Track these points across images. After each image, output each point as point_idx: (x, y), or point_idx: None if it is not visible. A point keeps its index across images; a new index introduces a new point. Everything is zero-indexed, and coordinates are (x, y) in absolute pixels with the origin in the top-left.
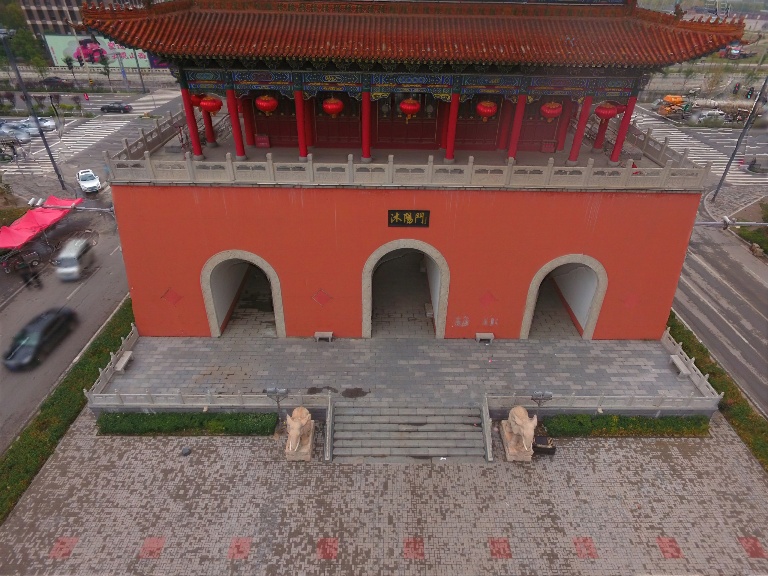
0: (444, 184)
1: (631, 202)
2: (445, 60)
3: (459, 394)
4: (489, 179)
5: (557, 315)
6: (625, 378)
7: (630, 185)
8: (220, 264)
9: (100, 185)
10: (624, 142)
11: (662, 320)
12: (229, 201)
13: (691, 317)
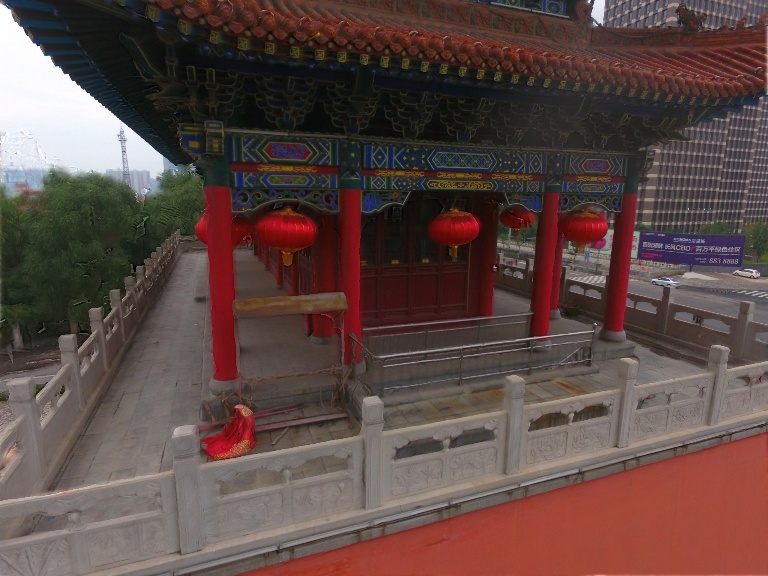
0: None
1: None
2: None
3: None
4: None
5: None
6: None
7: None
8: None
9: None
10: None
11: None
12: None
13: None
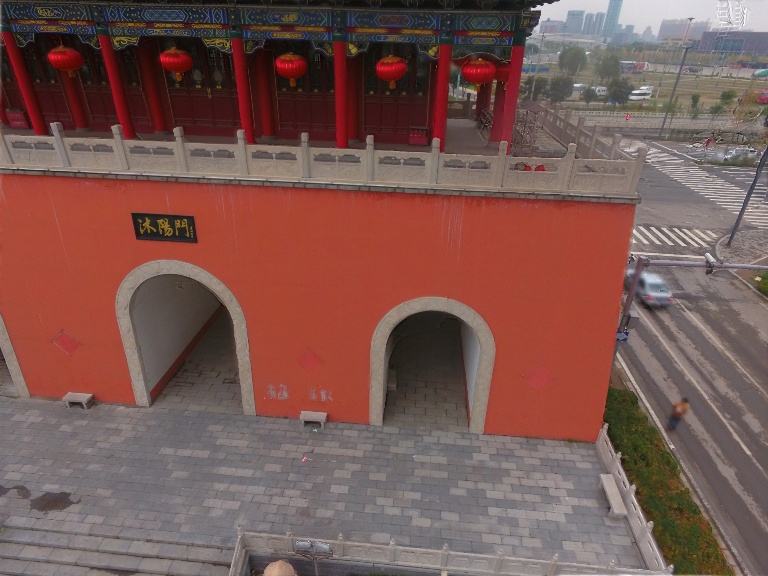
0: (206, 174)
1: (514, 214)
2: None
3: (217, 519)
4: (277, 168)
5: (446, 389)
6: (512, 511)
7: (509, 185)
8: None
9: None
10: (548, 139)
11: (595, 411)
12: None
13: (664, 404)
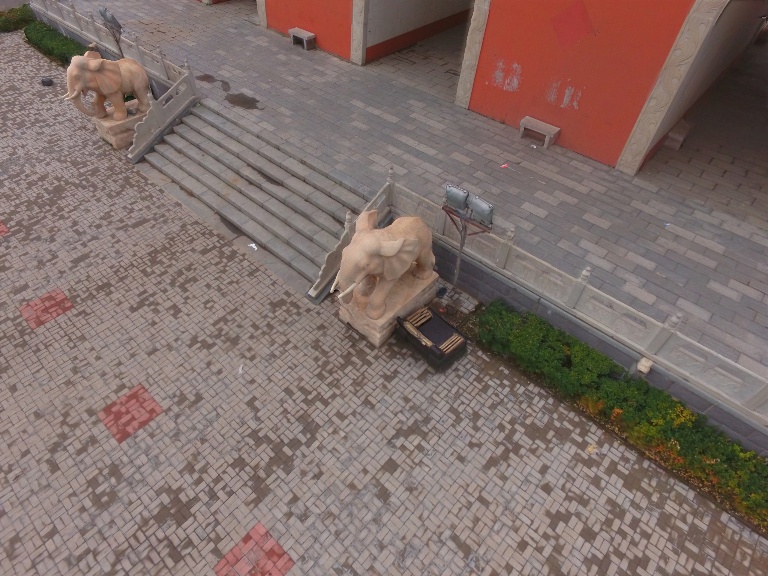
0: None
1: None
2: None
3: (376, 173)
4: None
5: None
6: None
7: None
8: None
9: None
10: None
11: None
12: None
13: None
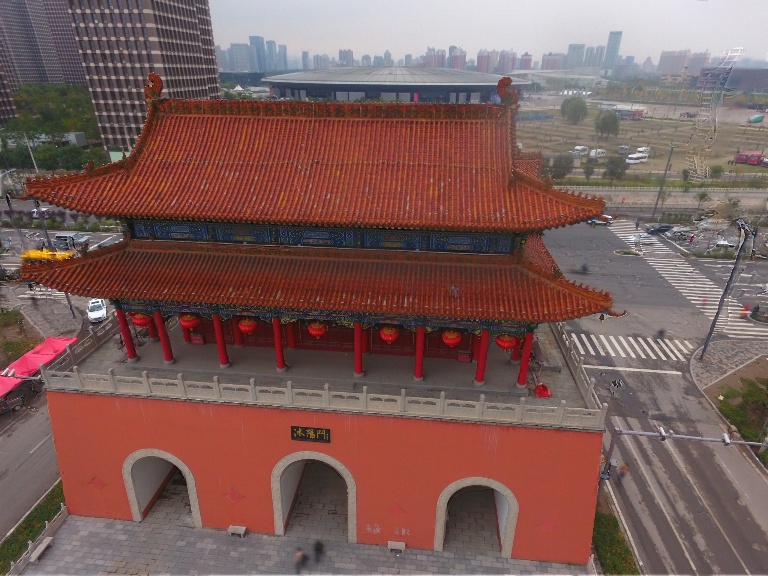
0: (341, 408)
1: (529, 435)
2: (331, 310)
3: None
4: (384, 406)
5: (483, 519)
6: None
7: (526, 420)
8: (140, 460)
9: (106, 315)
10: (549, 347)
11: (585, 546)
12: (147, 409)
13: (638, 526)
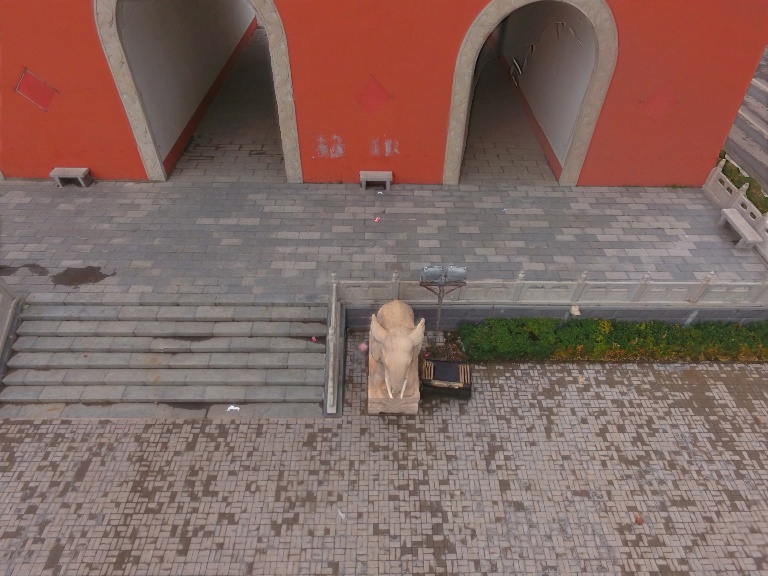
0: None
1: None
2: None
3: (294, 278)
4: None
5: (520, 148)
6: (632, 250)
7: None
8: None
9: None
10: None
11: (712, 146)
12: None
13: (750, 160)
